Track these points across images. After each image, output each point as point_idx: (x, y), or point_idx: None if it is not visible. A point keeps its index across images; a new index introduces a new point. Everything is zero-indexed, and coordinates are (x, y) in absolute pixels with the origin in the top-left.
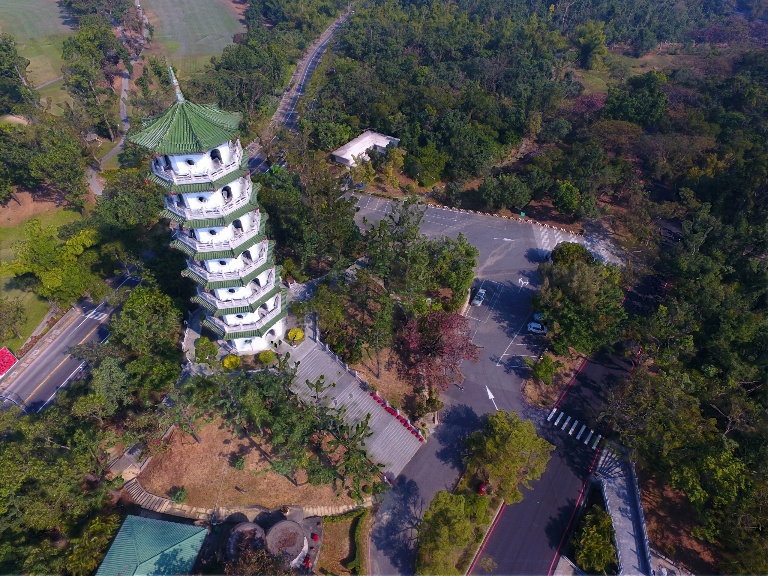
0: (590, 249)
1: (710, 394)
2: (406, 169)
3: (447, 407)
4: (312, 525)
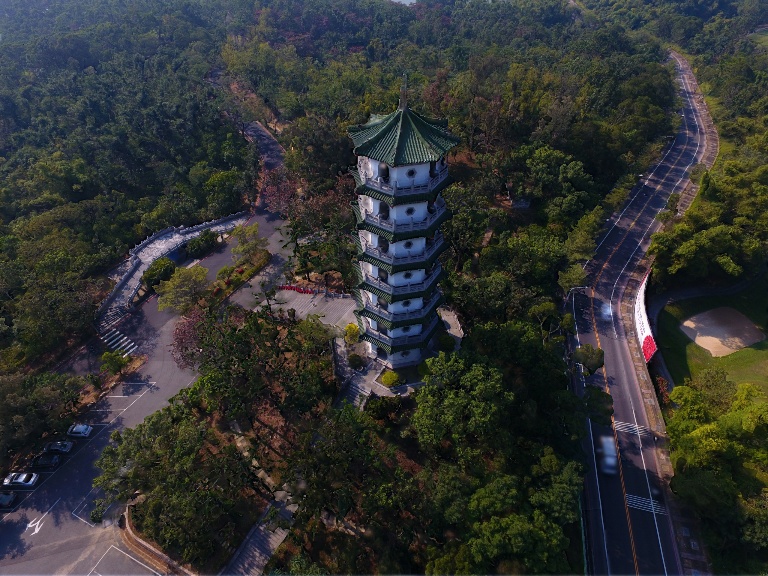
0: None
1: None
2: None
3: None
4: None
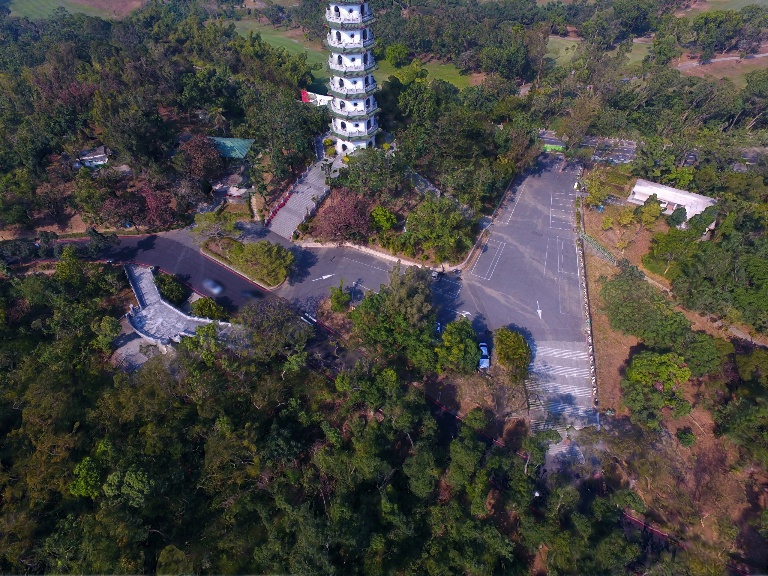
0: (566, 410)
1: (302, 417)
2: None
3: (316, 252)
4: (245, 196)
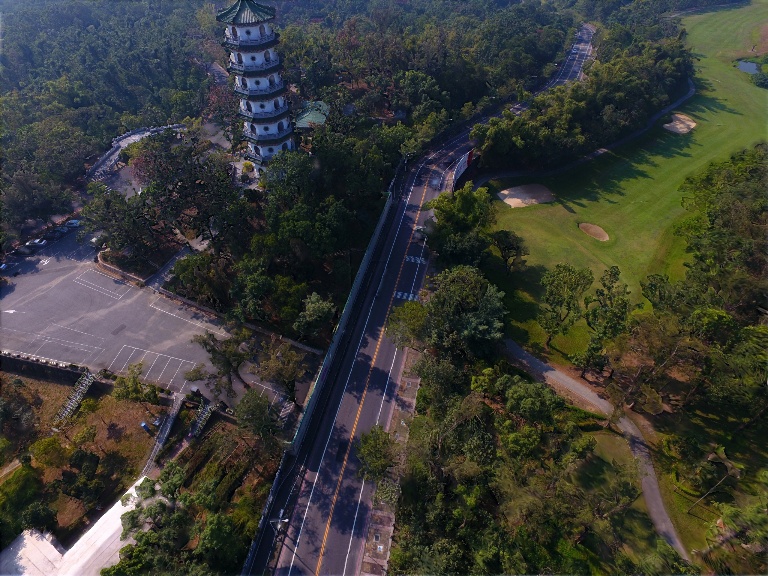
0: None
1: (8, 183)
2: (37, 498)
3: None
4: None
